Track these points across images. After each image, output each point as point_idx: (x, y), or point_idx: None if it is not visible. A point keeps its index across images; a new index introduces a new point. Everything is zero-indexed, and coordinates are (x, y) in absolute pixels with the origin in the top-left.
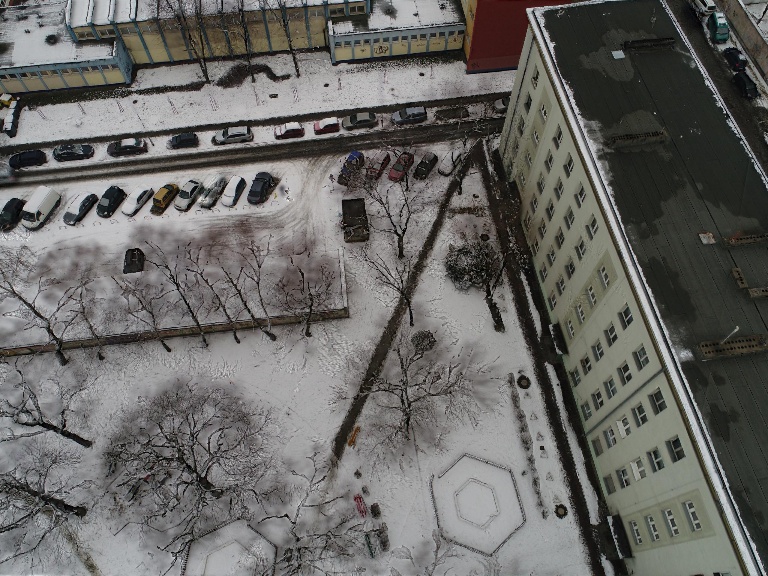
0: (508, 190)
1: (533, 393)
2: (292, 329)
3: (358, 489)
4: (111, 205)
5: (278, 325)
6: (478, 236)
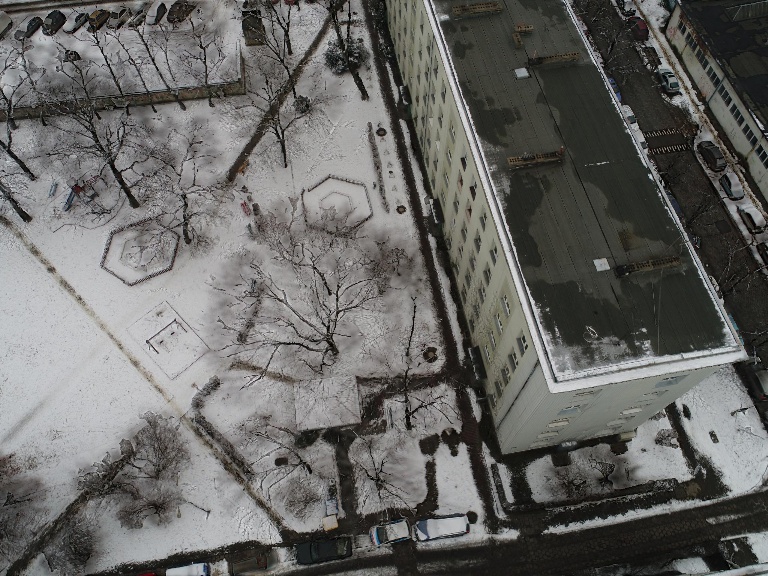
0: (377, 1)
1: (388, 139)
2: (199, 103)
3: (245, 200)
4: (54, 24)
5: (188, 100)
6: None
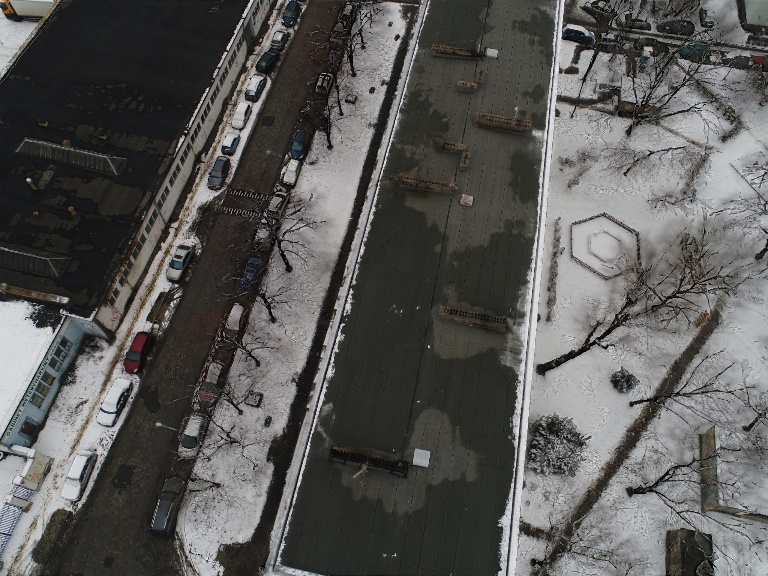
0: None
1: None
2: None
3: None
4: None
5: None
6: (529, 487)
